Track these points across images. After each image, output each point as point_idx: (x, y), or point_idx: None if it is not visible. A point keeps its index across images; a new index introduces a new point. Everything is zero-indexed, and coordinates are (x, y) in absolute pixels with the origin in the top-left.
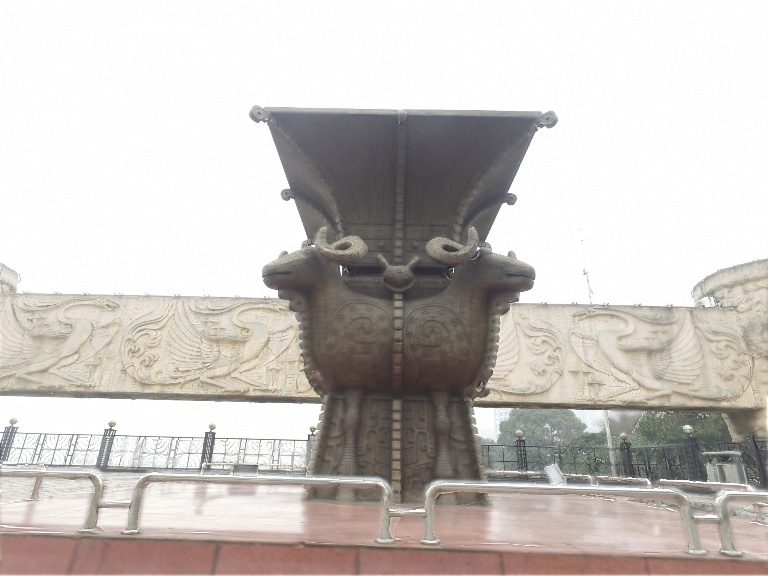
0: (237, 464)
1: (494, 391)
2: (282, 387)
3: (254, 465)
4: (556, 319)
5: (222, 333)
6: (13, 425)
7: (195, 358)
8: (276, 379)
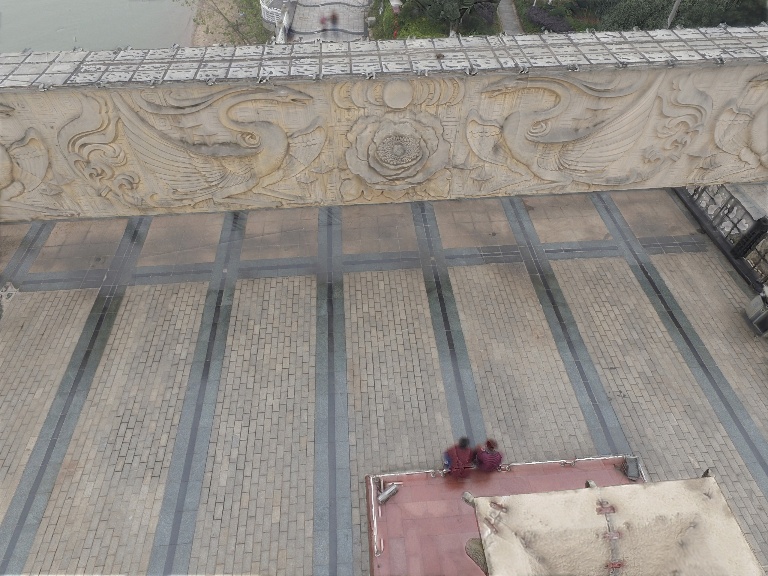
0: (383, 498)
1: (584, 183)
2: (323, 197)
3: None
4: (721, 86)
5: (214, 140)
6: None
7: (192, 176)
8: (313, 190)
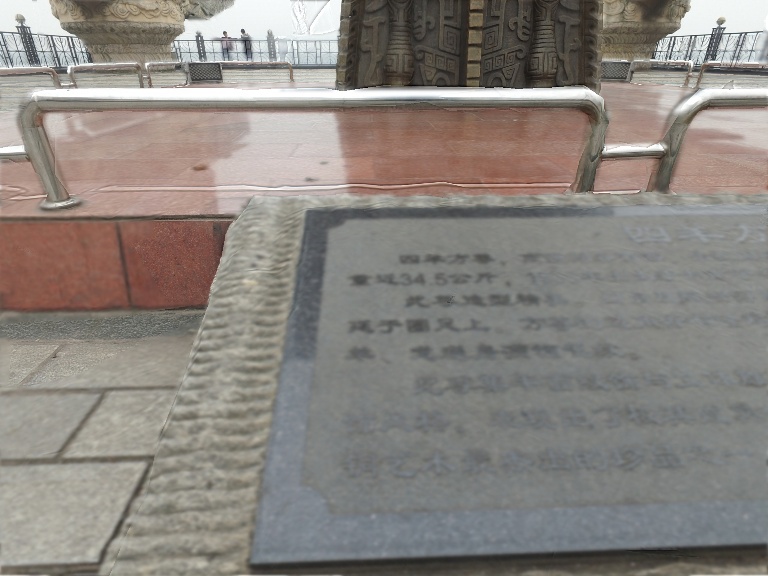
0: None
1: None
2: None
3: (626, 62)
4: None
5: None
6: (720, 26)
7: None
8: None
